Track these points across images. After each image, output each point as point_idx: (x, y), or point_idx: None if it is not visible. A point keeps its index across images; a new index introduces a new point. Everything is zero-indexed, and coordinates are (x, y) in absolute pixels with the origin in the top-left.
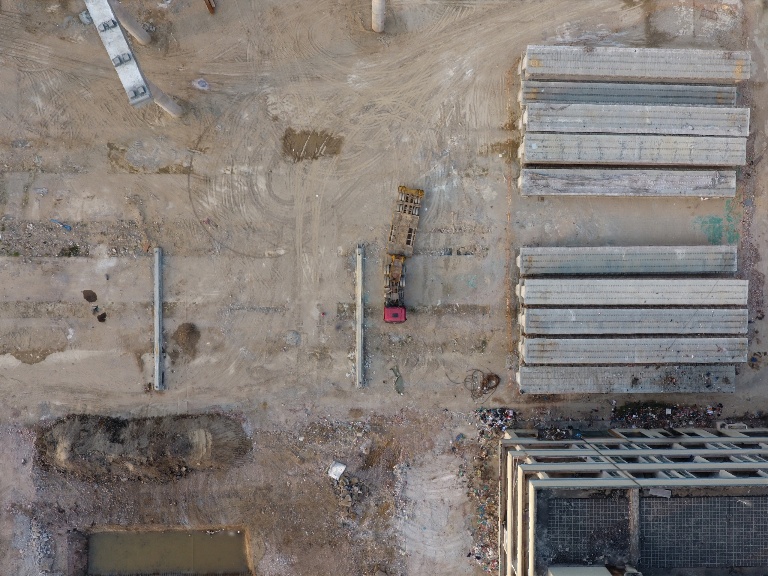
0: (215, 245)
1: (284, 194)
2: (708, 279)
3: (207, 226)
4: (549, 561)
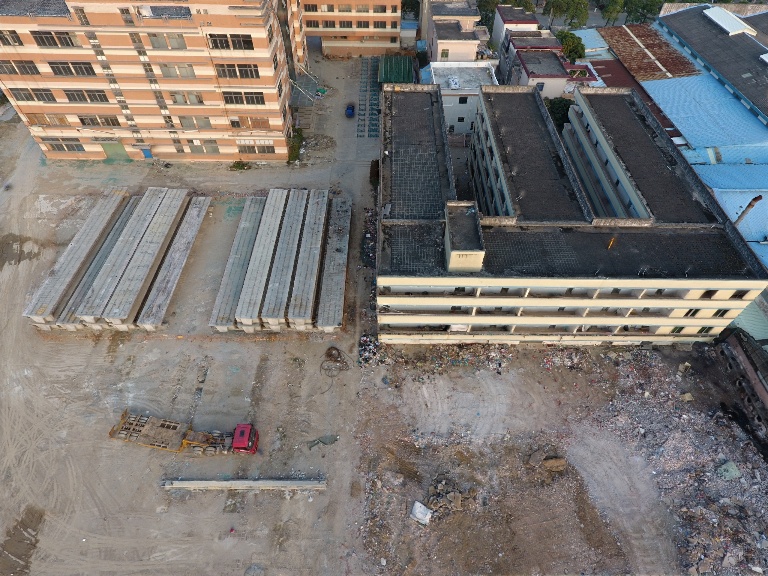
0: None
1: None
2: (264, 208)
3: None
4: (443, 272)
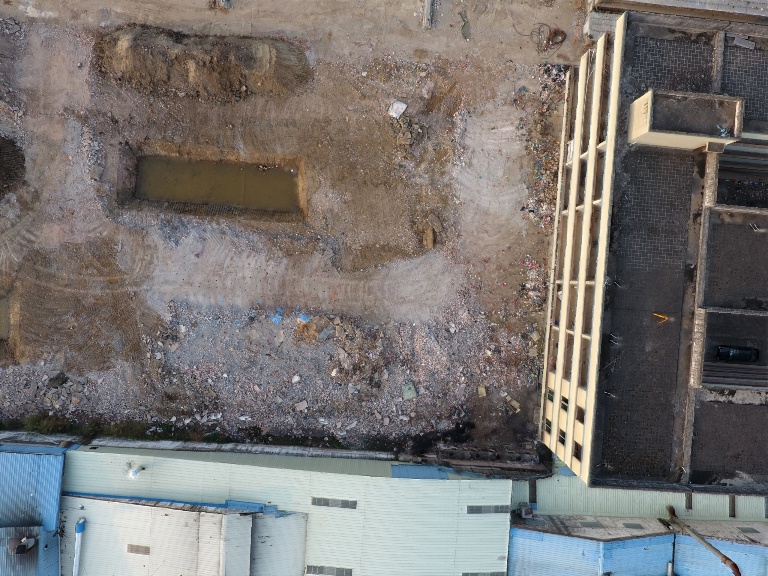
0: None
1: None
2: None
3: None
4: (631, 99)
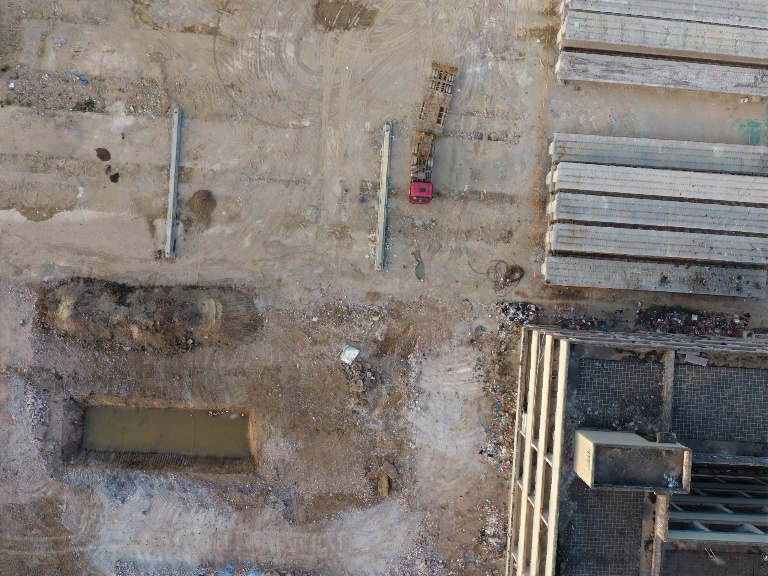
0: (238, 111)
1: (313, 63)
2: (746, 175)
3: (231, 91)
4: (577, 424)
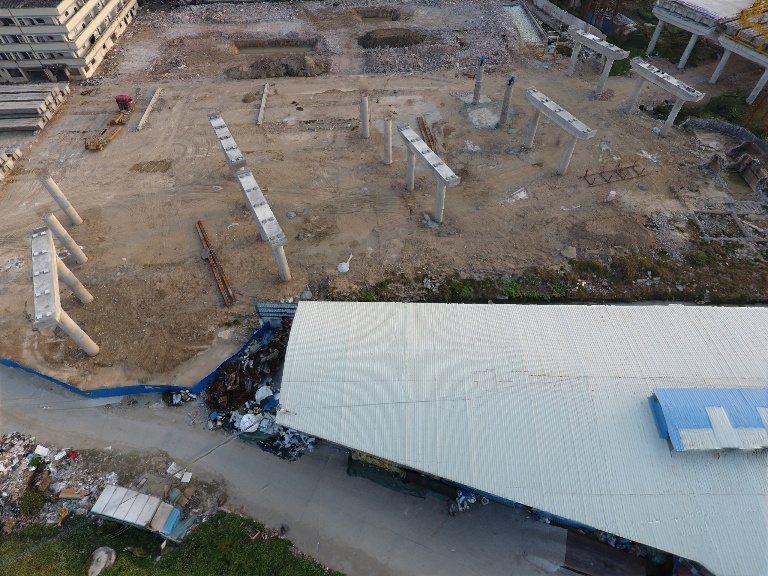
0: None
1: (177, 147)
2: None
3: None
4: None
